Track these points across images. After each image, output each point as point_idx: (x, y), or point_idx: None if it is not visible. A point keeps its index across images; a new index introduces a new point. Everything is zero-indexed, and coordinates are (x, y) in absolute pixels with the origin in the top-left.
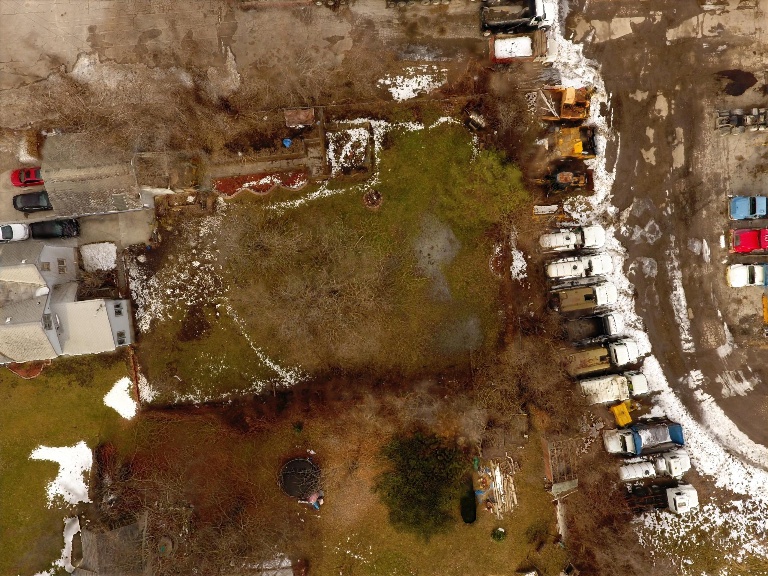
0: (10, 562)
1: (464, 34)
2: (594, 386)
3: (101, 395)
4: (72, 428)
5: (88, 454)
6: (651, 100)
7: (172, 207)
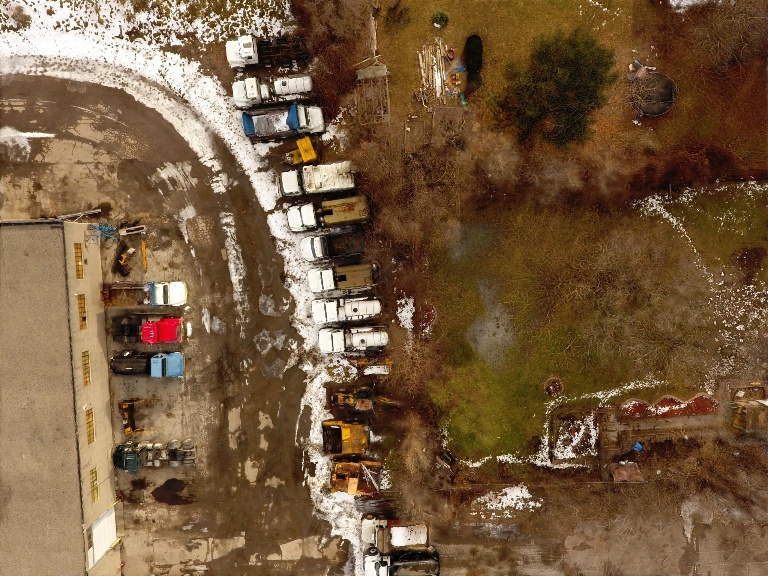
0: None
1: (452, 548)
2: (341, 182)
3: None
4: None
5: None
6: (262, 477)
7: (760, 386)
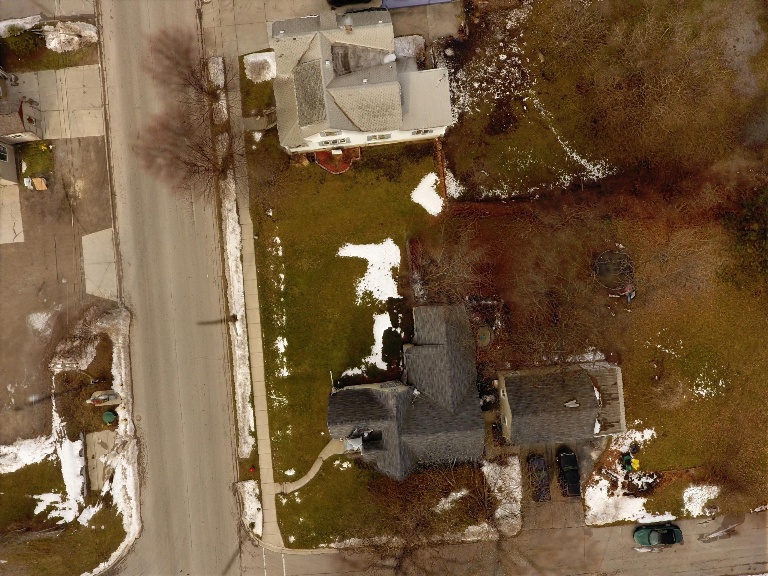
0: (320, 359)
1: None
2: None
3: (409, 191)
4: (379, 225)
5: (396, 251)
6: None
7: None
